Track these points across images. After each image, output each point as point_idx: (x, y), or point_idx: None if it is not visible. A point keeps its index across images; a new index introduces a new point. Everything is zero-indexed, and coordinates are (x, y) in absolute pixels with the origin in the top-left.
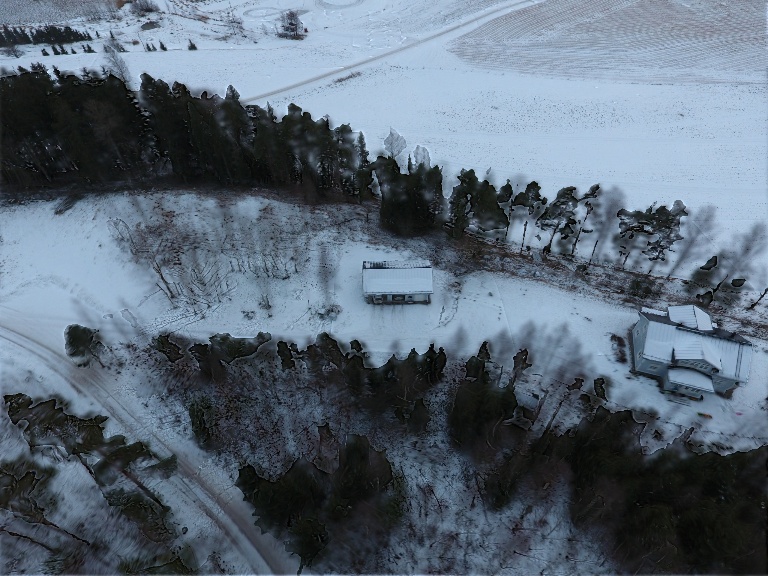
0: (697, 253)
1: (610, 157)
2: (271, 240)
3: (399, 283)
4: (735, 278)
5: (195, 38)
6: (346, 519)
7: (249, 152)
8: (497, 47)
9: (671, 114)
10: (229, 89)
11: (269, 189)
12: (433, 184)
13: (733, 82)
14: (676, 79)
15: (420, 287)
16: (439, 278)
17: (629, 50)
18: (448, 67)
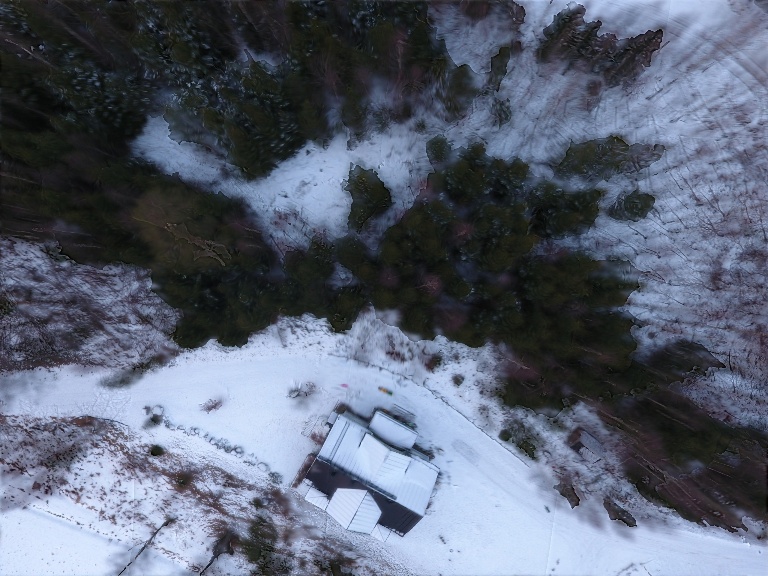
0: None
1: None
2: None
3: None
4: (142, 574)
5: None
6: None
7: None
8: None
9: None
10: None
11: None
12: None
13: None
14: None
15: None
16: None
17: None
18: None
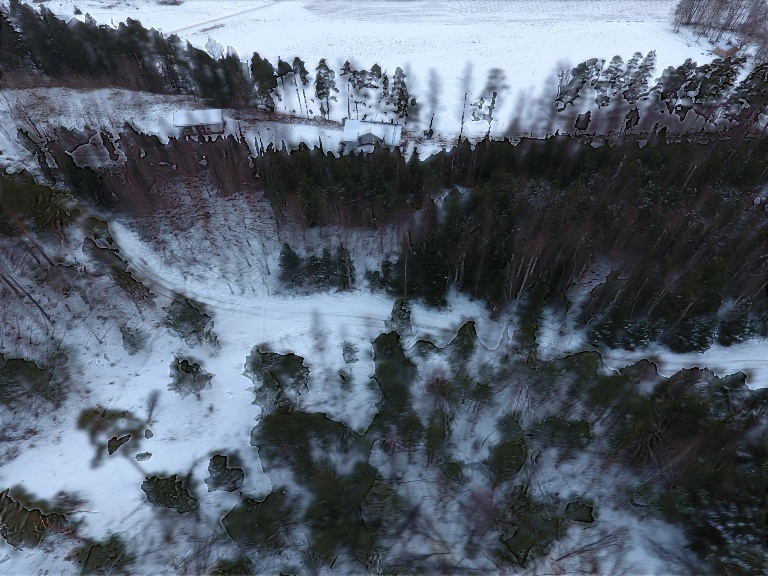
0: (443, 118)
1: (408, 70)
2: (118, 109)
3: (198, 118)
4: None
5: (82, 7)
6: (135, 206)
7: (105, 60)
8: (344, 3)
9: (466, 42)
10: (86, 16)
11: (124, 87)
12: (232, 65)
13: (523, 20)
14: (481, 20)
15: (213, 120)
16: (235, 123)
17: (450, 1)
18: (299, 18)
